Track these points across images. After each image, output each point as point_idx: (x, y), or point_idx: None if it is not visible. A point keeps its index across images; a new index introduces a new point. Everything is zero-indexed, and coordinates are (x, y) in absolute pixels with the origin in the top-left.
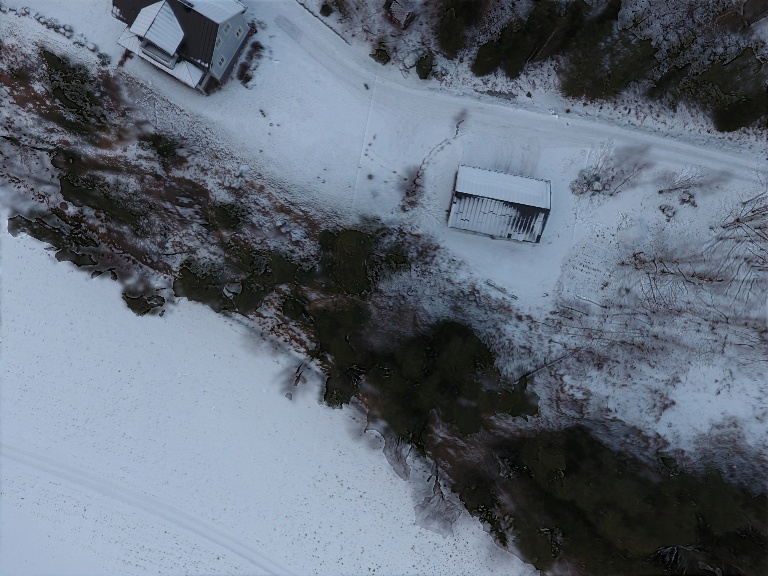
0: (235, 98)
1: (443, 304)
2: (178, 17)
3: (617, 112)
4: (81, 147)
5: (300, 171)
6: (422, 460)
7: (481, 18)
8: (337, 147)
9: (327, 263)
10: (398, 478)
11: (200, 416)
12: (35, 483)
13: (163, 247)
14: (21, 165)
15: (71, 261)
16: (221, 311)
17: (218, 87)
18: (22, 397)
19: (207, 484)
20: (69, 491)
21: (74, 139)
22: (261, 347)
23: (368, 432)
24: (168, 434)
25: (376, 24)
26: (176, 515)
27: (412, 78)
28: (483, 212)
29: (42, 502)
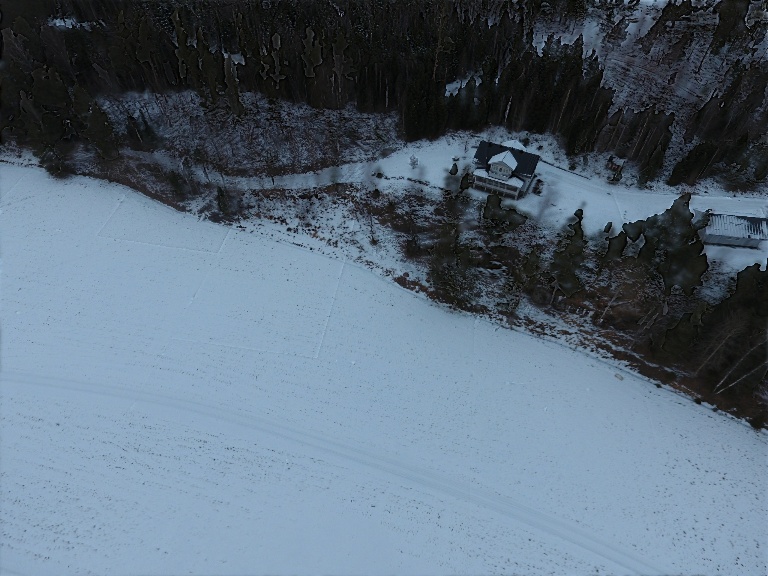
0: (534, 200)
1: (721, 290)
2: (515, 157)
3: (763, 196)
4: (421, 242)
5: (587, 228)
6: (764, 434)
7: (660, 166)
8: (605, 216)
9: (661, 226)
10: (751, 453)
11: (535, 416)
12: (386, 488)
13: (479, 296)
14: (376, 255)
15: (465, 261)
16: (531, 335)
17: (522, 197)
18: (372, 407)
19: (560, 481)
20: (421, 496)
21: (415, 239)
22: (574, 356)
23: (699, 414)
24: (509, 434)
25: (602, 171)
26: (536, 518)
27: (633, 190)
28: (726, 223)
29: (393, 509)
